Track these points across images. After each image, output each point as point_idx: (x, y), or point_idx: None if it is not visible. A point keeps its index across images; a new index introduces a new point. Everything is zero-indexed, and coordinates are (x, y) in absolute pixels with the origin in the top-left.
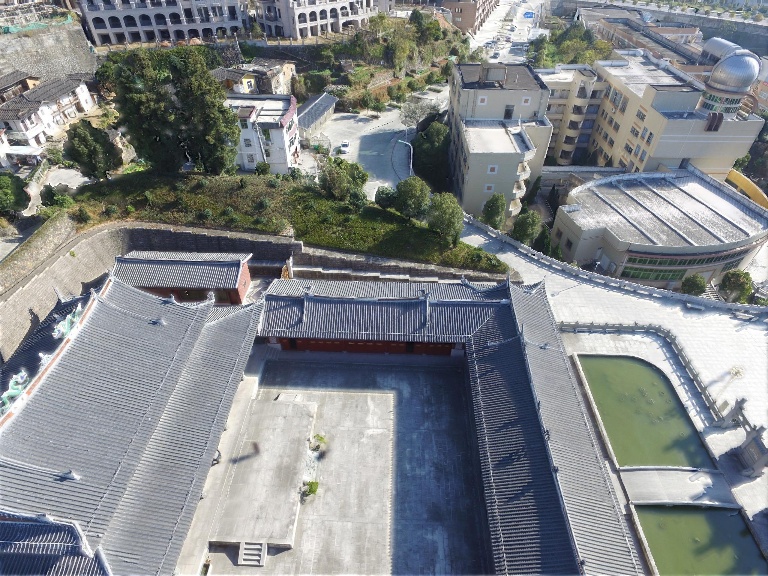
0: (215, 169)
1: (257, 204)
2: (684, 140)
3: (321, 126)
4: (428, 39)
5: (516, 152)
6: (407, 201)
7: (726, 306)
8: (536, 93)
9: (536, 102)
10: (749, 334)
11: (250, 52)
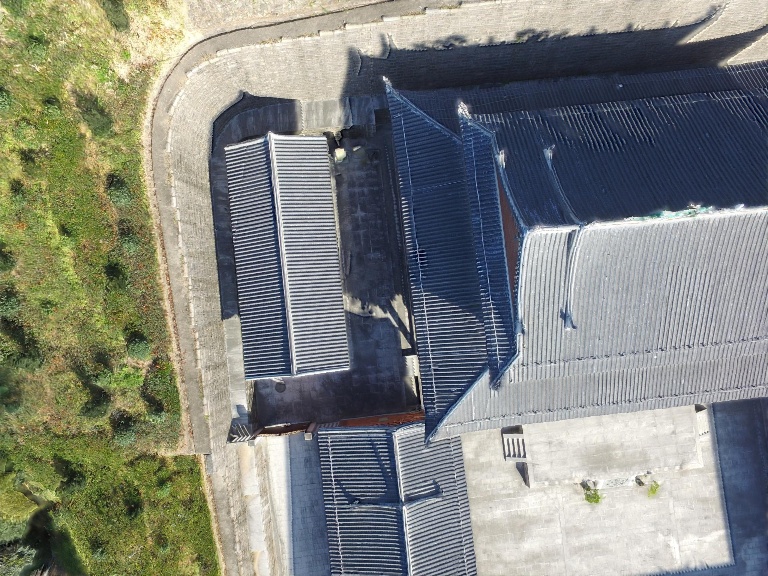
0: None
1: None
2: None
3: None
4: None
5: None
6: None
7: None
8: None
9: None
10: None
11: None
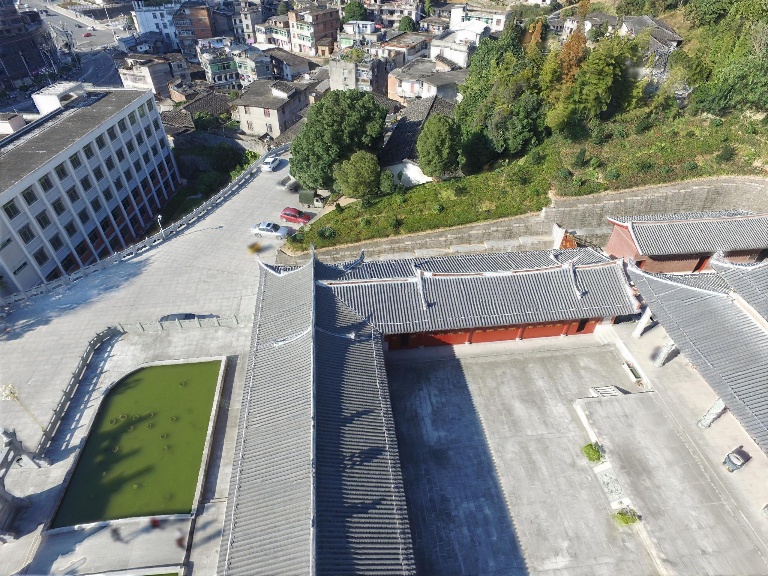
0: None
1: None
2: None
3: None
4: None
5: None
6: None
7: None
8: None
9: None
10: None
11: None
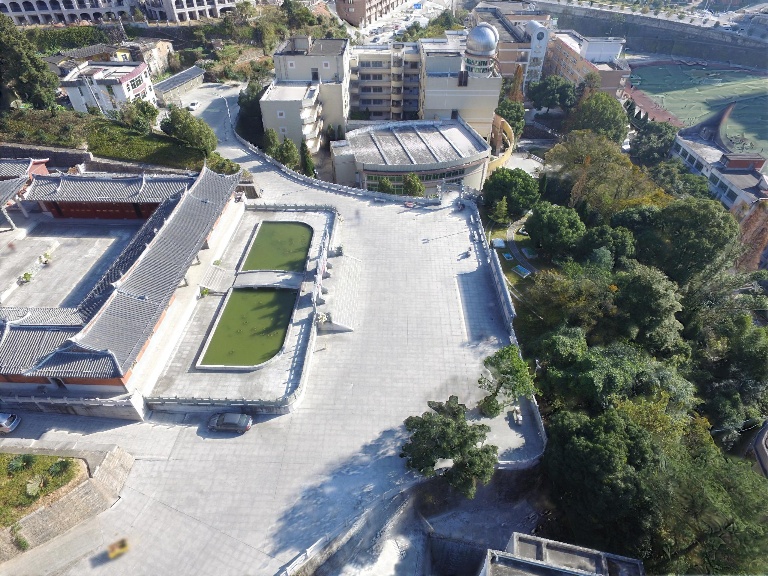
0: (40, 105)
1: (63, 128)
2: (445, 94)
3: (186, 92)
4: (302, 24)
5: (295, 100)
6: (175, 126)
7: (402, 199)
8: (332, 58)
9: (334, 66)
10: (405, 214)
11: (134, 32)
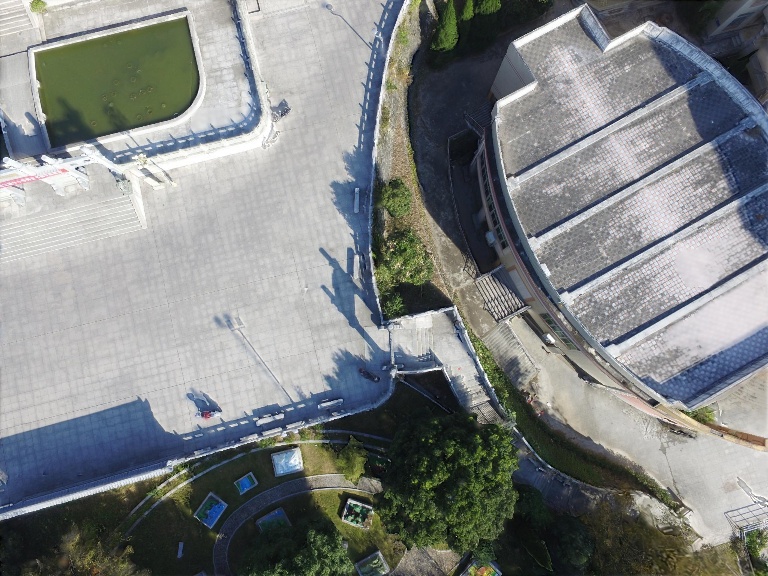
0: None
1: None
2: None
3: None
4: None
5: None
6: None
7: None
8: None
9: None
10: (319, 265)
11: None
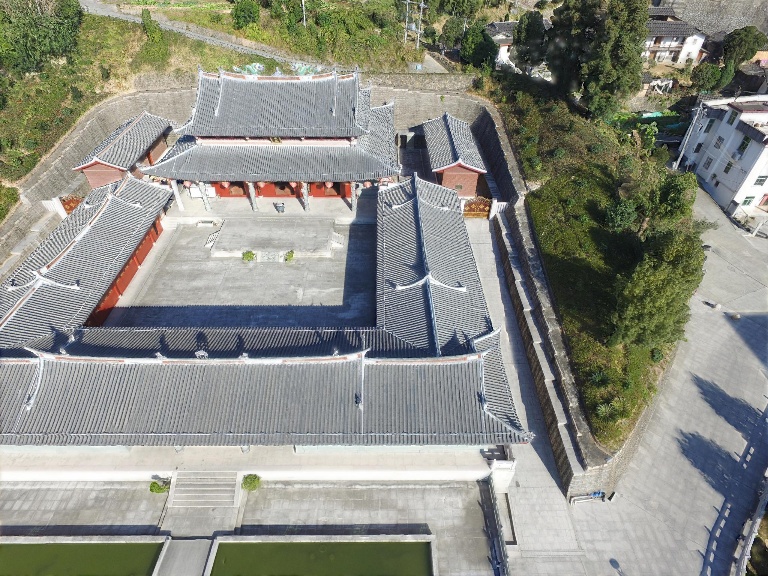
0: (590, 112)
1: None
2: None
3: None
4: None
5: None
6: (645, 253)
7: None
8: None
9: None
10: None
11: None
